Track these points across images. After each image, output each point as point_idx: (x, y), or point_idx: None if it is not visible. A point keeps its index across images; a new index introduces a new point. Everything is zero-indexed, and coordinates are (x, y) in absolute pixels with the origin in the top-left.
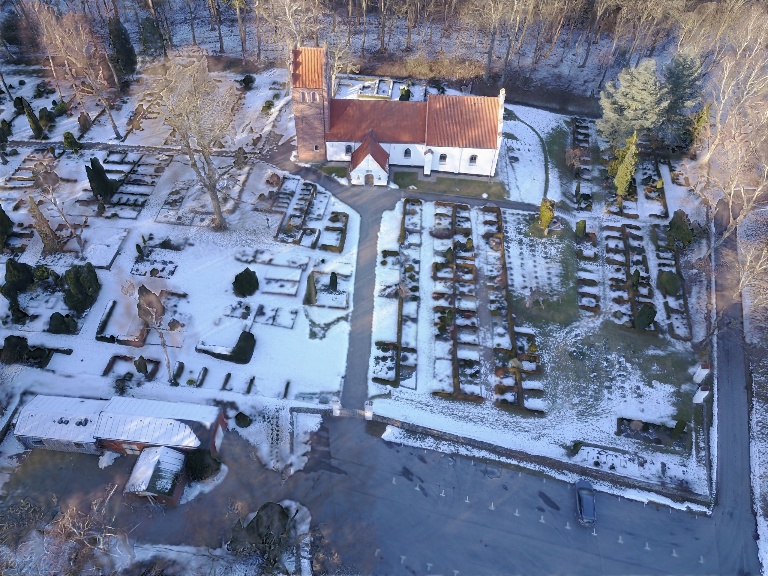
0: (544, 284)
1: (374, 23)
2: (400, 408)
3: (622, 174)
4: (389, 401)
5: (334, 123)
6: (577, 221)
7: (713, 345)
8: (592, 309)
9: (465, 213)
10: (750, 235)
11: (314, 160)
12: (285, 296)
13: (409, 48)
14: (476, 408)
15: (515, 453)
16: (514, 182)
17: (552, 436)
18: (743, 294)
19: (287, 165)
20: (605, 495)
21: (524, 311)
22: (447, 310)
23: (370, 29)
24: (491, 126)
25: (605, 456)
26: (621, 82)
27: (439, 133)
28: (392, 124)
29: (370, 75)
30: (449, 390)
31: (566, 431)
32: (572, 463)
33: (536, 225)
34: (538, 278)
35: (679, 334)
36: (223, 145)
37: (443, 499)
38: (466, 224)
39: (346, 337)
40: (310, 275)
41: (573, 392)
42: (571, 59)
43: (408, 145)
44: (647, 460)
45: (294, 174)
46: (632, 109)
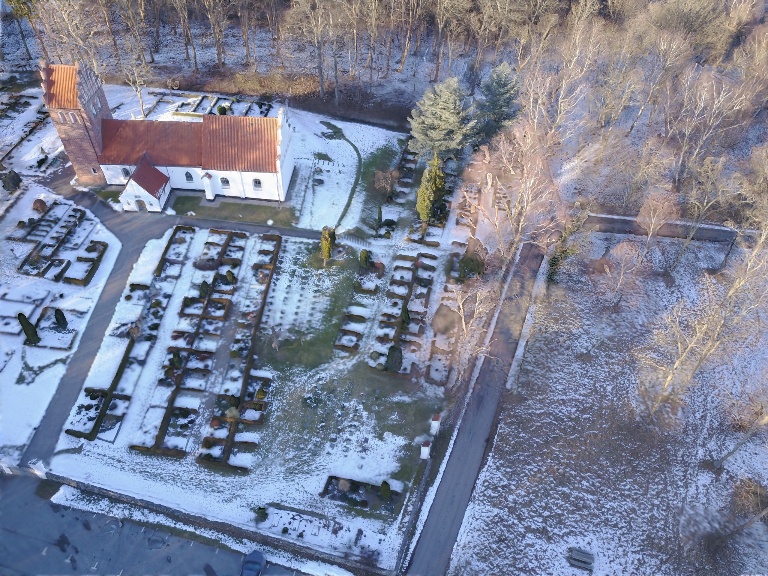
0: (302, 321)
1: (237, 35)
2: (86, 464)
3: (420, 199)
4: (76, 456)
5: (106, 145)
6: (370, 249)
7: (468, 391)
8: (347, 349)
9: (241, 242)
10: (554, 265)
11: (94, 184)
12: (7, 335)
13: (249, 62)
14: (173, 464)
15: (193, 518)
16: (309, 207)
17: (247, 497)
18: (523, 332)
19: (64, 189)
20: (280, 569)
21: (269, 352)
22: (181, 351)
23: (230, 42)
24: (270, 148)
25: (298, 521)
26: (425, 100)
27: (215, 156)
28: (167, 146)
29: (199, 91)
30: (150, 443)
31: (265, 492)
32: (253, 531)
33: (317, 255)
34: (298, 314)
35: (435, 378)
36: (4, 167)
37: (92, 573)
38: (237, 254)
39: (56, 382)
40: (19, 314)
41: (290, 445)
42: (427, 73)
43: (185, 168)
44: (343, 526)
45: (68, 199)
46: (441, 129)
